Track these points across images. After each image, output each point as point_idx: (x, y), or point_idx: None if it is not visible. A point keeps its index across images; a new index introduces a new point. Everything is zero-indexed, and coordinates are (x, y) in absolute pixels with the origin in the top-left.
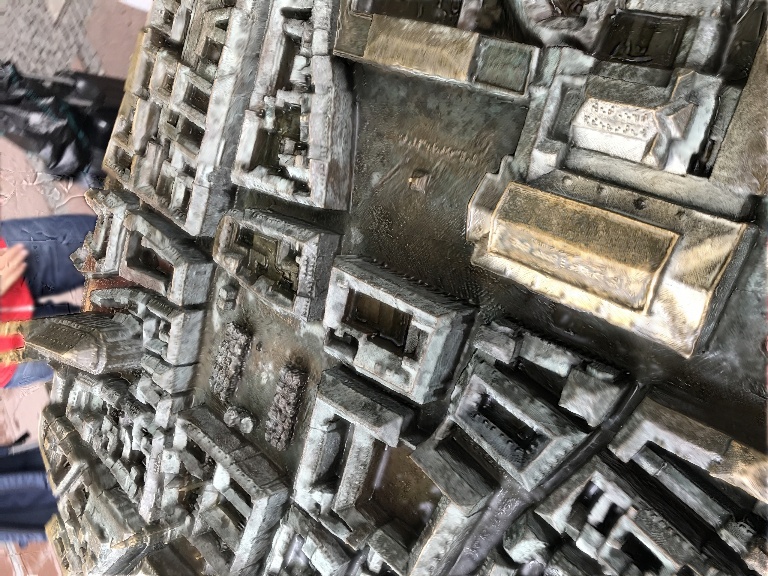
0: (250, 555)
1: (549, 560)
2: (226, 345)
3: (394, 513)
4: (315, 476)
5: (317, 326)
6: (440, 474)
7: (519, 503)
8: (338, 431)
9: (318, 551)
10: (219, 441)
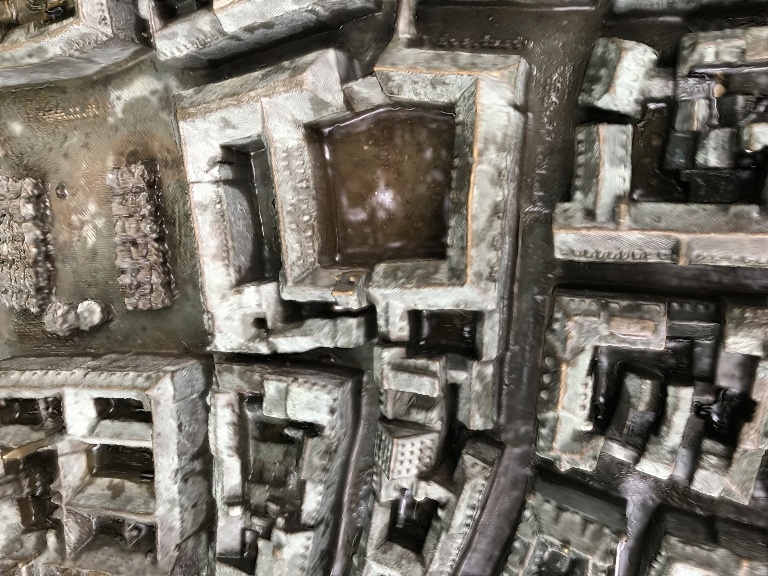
0: (182, 511)
1: (675, 68)
2: (5, 219)
3: (385, 254)
4: (233, 271)
5: (138, 79)
6: (437, 62)
7: (572, 65)
8: (239, 189)
9: (292, 388)
10: (52, 367)
